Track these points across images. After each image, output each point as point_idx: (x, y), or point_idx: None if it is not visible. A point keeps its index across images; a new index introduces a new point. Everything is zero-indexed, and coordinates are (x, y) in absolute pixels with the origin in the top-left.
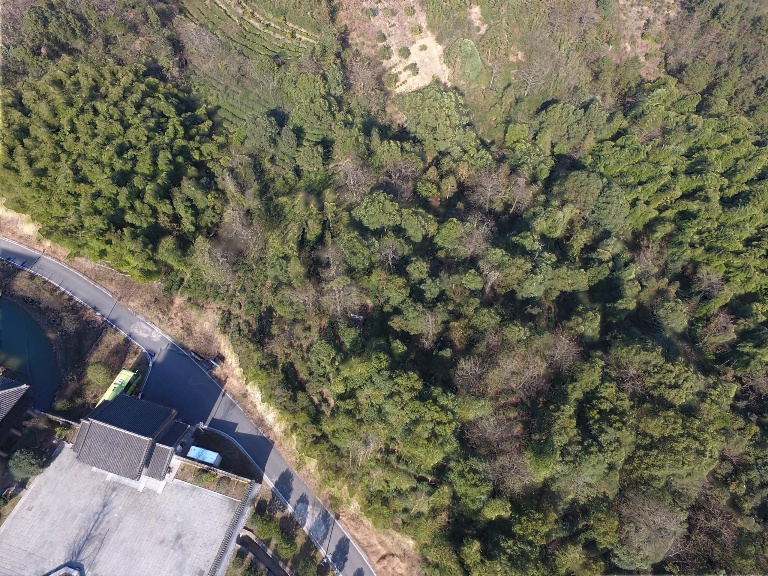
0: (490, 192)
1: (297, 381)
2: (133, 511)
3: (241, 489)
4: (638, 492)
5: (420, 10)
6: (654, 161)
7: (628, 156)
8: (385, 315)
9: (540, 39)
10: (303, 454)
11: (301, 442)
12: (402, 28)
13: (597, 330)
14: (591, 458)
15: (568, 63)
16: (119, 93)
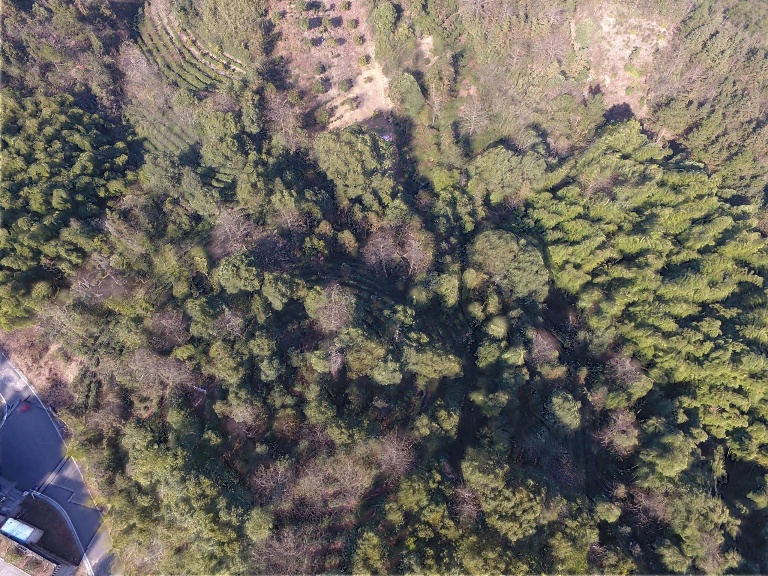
0: (383, 252)
1: (127, 456)
2: None
3: None
4: None
5: (370, 39)
6: (595, 218)
7: (564, 211)
8: (226, 392)
9: (495, 73)
10: None
11: None
12: (347, 59)
13: (453, 431)
14: None
15: (525, 100)
16: (33, 126)
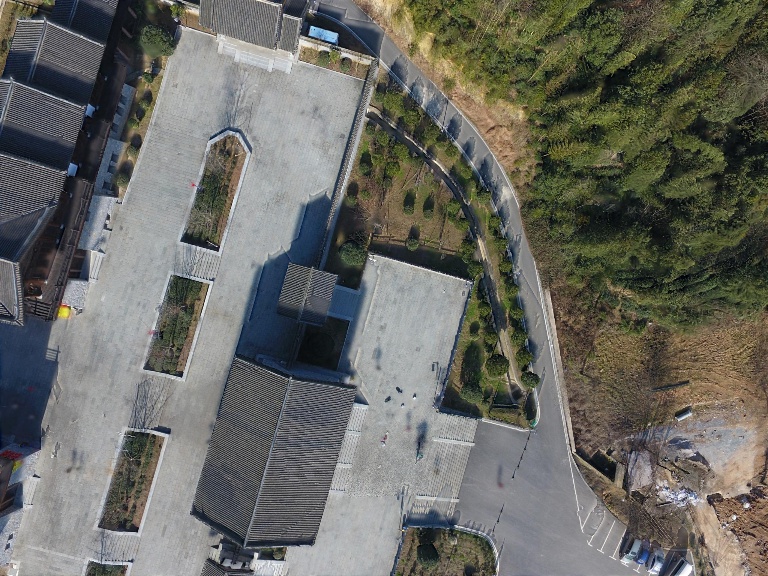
0: None
1: None
2: (269, 88)
3: (363, 70)
4: (747, 54)
5: None
6: None
7: None
8: None
9: None
10: (417, 38)
11: (420, 19)
12: None
13: None
14: (726, 8)
15: None
16: None
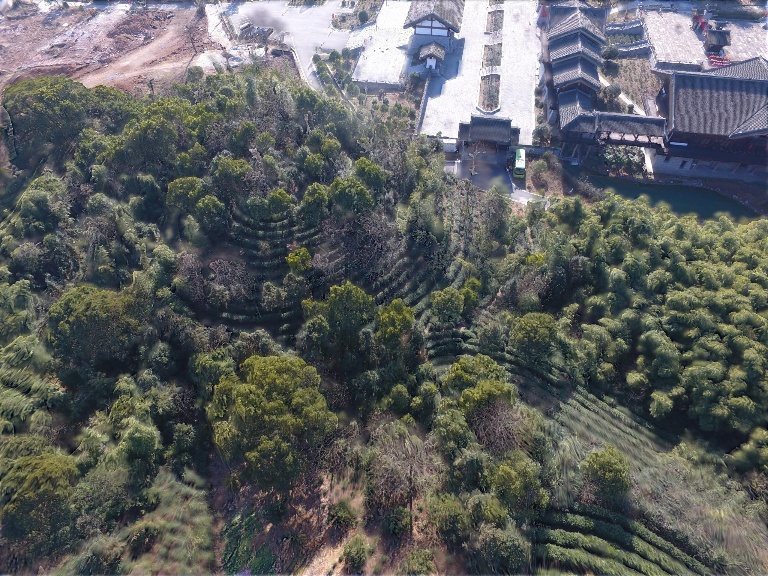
0: None
1: None
2: None
3: None
4: None
5: None
6: None
7: None
8: None
9: None
10: None
11: None
12: None
13: None
14: None
15: None
16: None
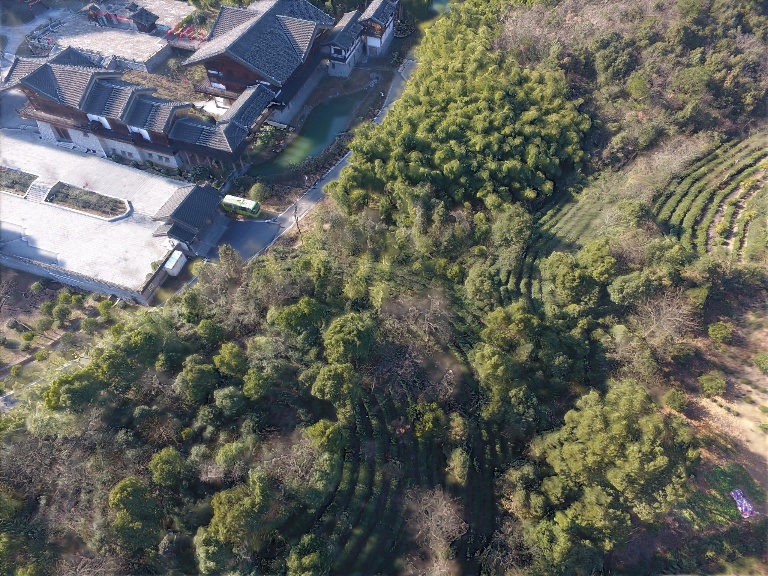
0: None
1: None
2: None
3: None
4: None
5: None
6: None
7: None
8: None
9: None
10: None
11: None
12: None
13: None
14: None
15: None
16: (531, 116)
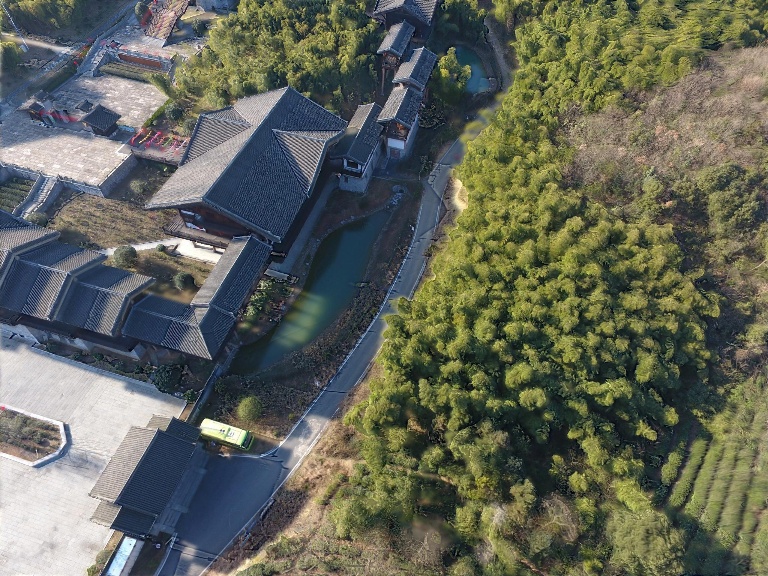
0: None
1: None
2: None
3: None
4: None
5: None
6: None
7: None
8: None
9: None
10: None
11: None
12: None
13: None
14: None
15: None
16: (637, 304)
